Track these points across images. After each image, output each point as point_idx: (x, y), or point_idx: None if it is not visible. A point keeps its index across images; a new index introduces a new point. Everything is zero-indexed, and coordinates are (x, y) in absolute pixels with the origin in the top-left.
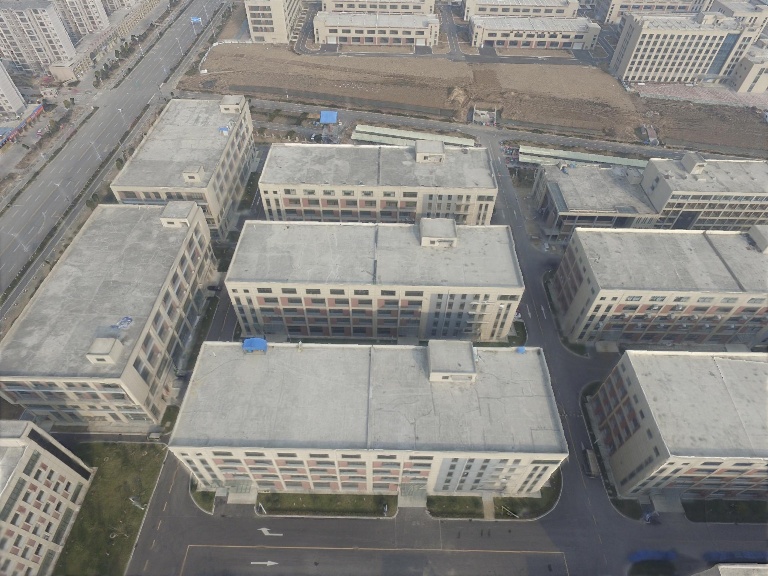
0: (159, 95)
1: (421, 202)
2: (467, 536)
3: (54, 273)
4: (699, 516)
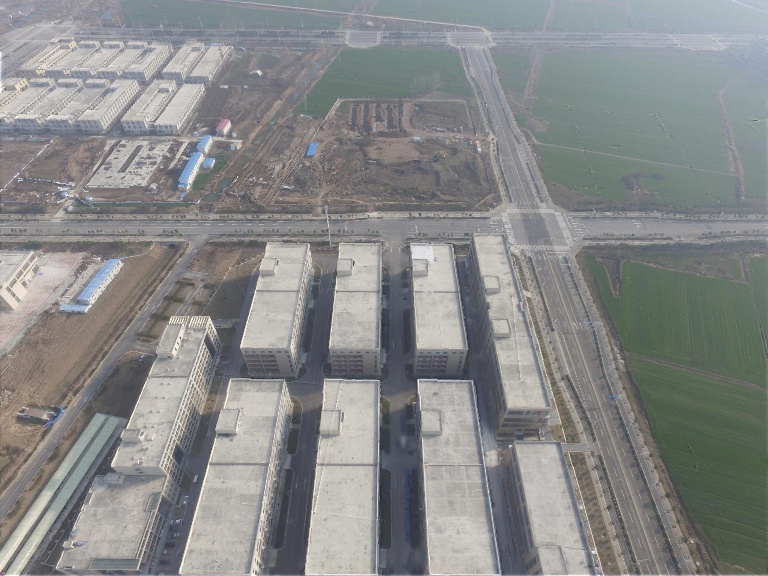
0: None
1: None
2: None
3: None
4: (388, 541)
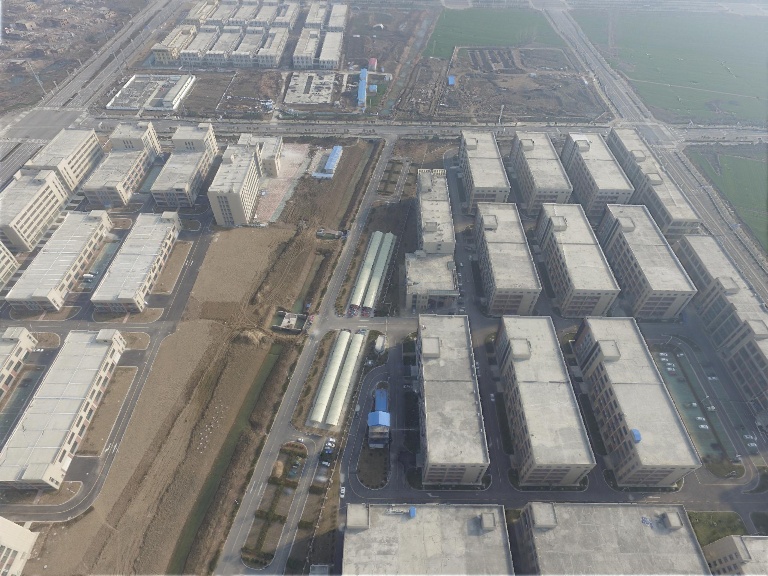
0: None
1: None
2: None
3: None
4: None
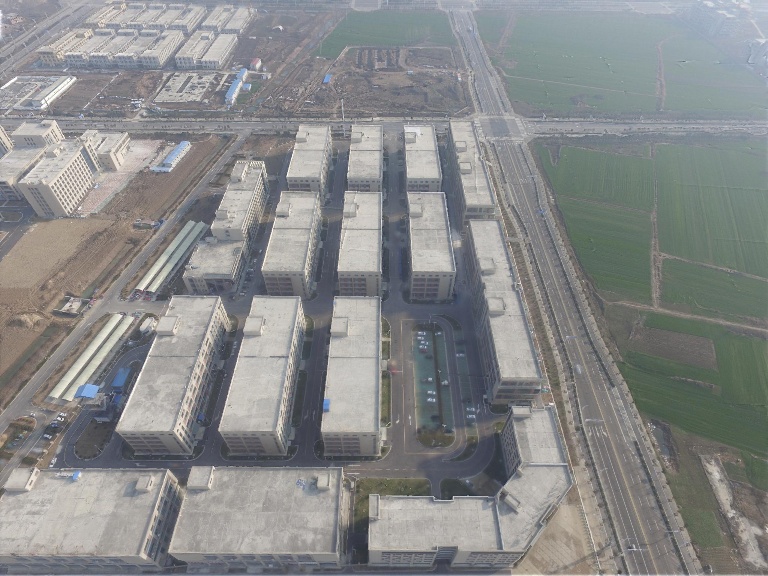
0: None
1: (211, 339)
2: (397, 347)
3: None
4: (388, 279)
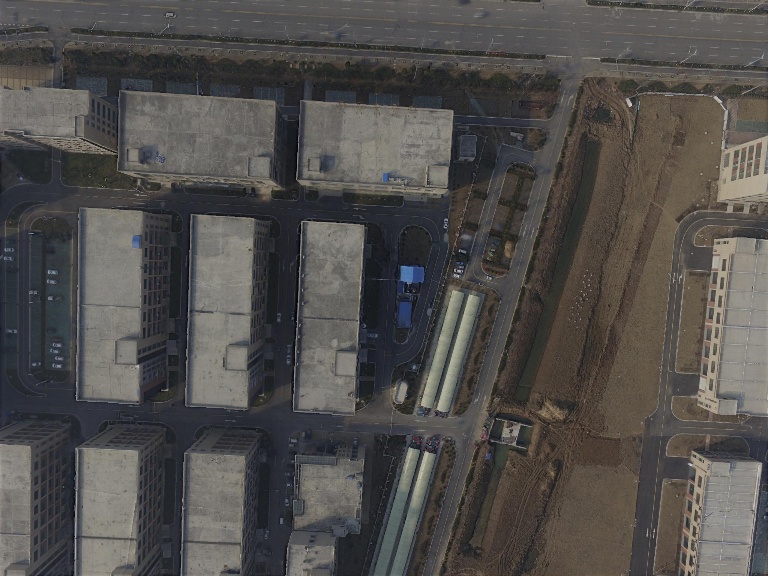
0: (569, 62)
1: None
2: None
3: (202, 97)
4: None
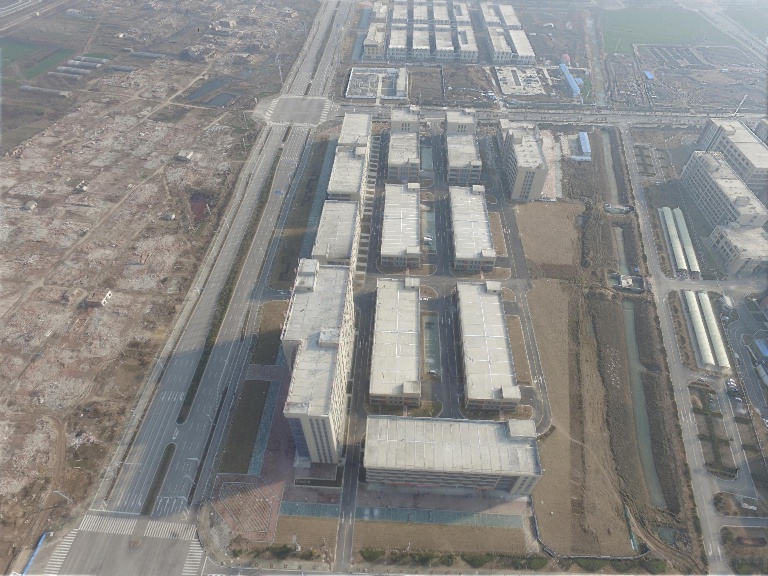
0: None
1: None
2: None
3: None
4: None
